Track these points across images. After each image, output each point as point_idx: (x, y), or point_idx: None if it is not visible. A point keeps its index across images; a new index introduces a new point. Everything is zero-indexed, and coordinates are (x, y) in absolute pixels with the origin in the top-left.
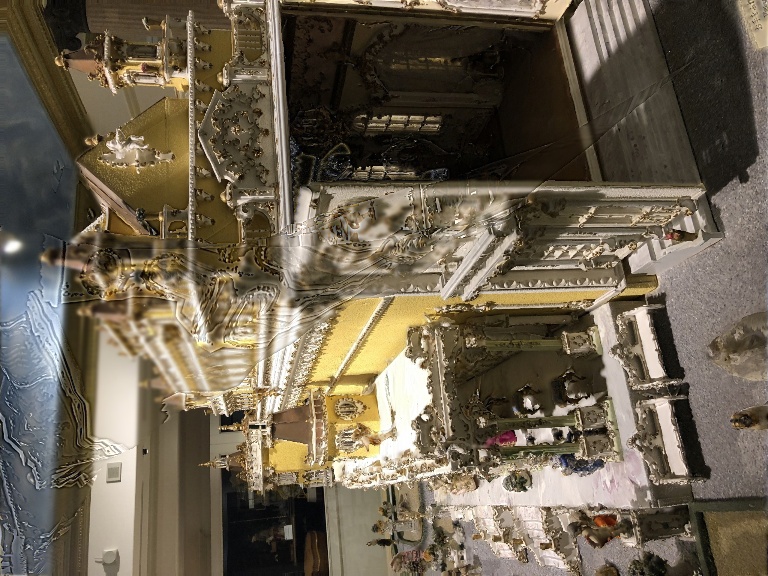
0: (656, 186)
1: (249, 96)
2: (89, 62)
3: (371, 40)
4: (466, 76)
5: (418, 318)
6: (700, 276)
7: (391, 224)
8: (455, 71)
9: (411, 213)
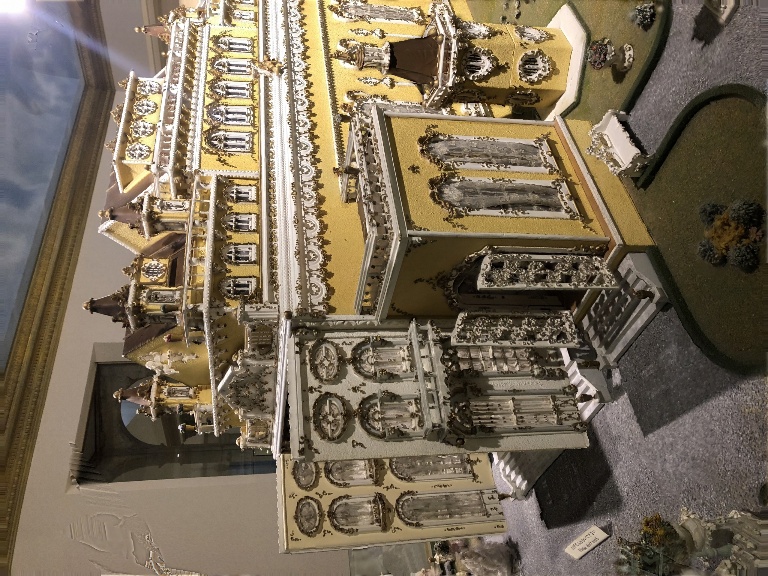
0: None
1: (258, 373)
2: None
3: None
4: None
5: None
6: None
7: None
8: None
9: None
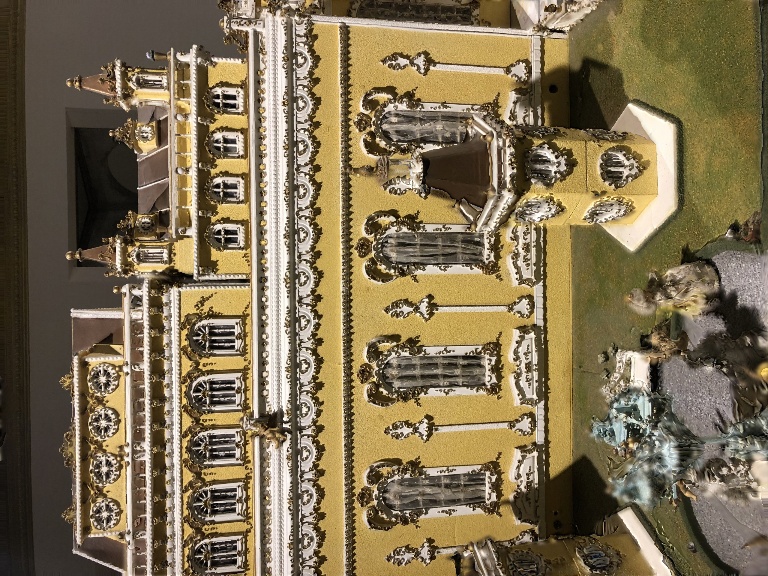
0: None
1: None
2: None
3: None
4: None
5: None
6: None
7: None
8: None
9: None
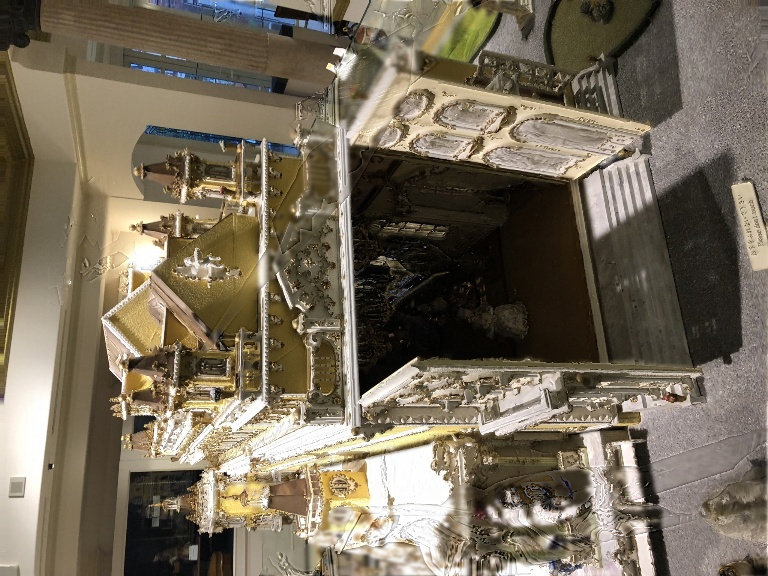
0: (670, 371)
1: (319, 230)
2: (168, 177)
3: (413, 173)
4: (480, 201)
5: (440, 431)
6: (681, 426)
7: (579, 500)
8: (472, 197)
9: (593, 493)
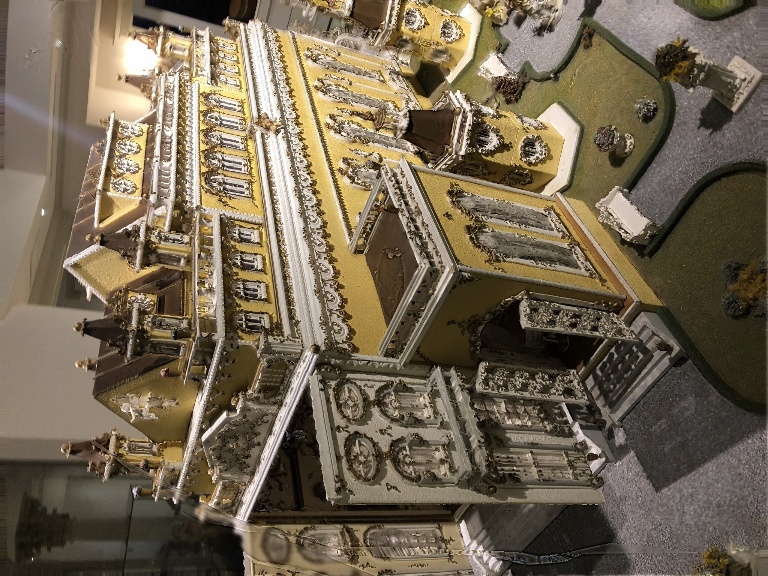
0: None
1: (254, 422)
2: None
3: None
4: None
5: None
6: None
7: None
8: None
9: None
